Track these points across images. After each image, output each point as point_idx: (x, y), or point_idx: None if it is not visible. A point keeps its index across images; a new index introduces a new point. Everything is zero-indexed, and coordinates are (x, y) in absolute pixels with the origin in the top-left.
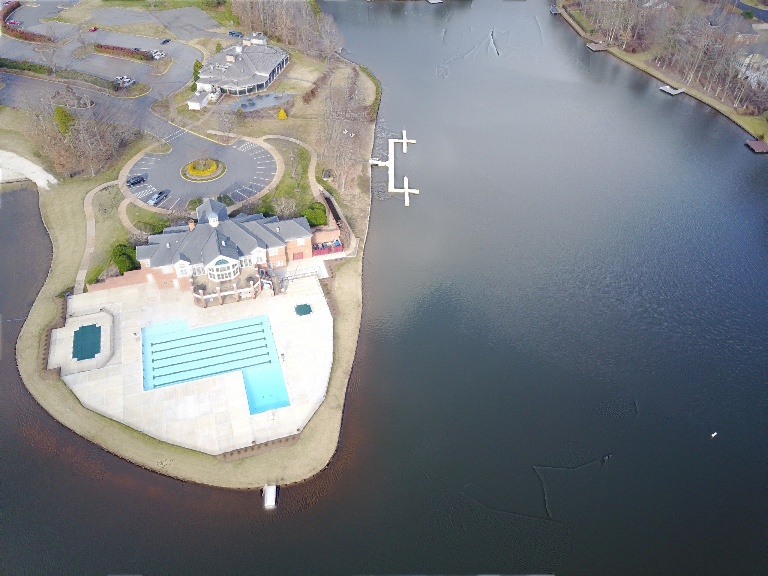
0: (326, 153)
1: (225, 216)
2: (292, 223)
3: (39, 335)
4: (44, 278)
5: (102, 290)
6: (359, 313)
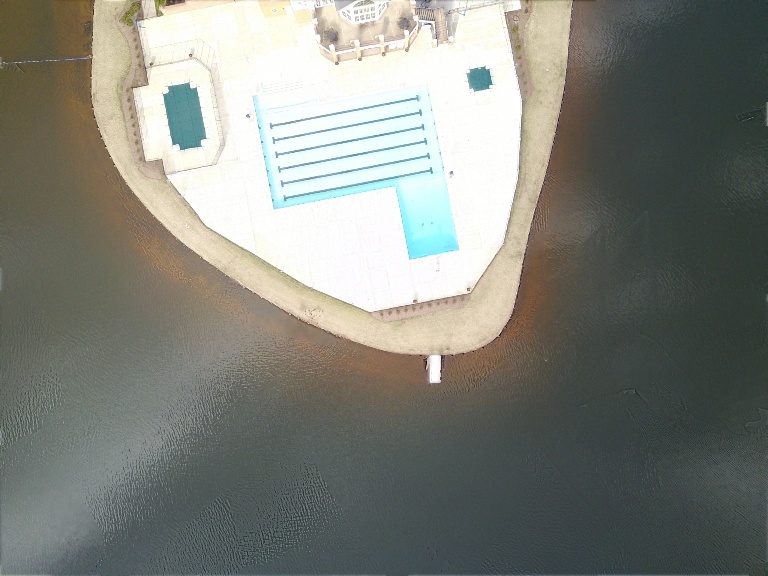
0: None
1: None
2: None
3: (118, 97)
4: None
5: (183, 12)
6: (560, 89)
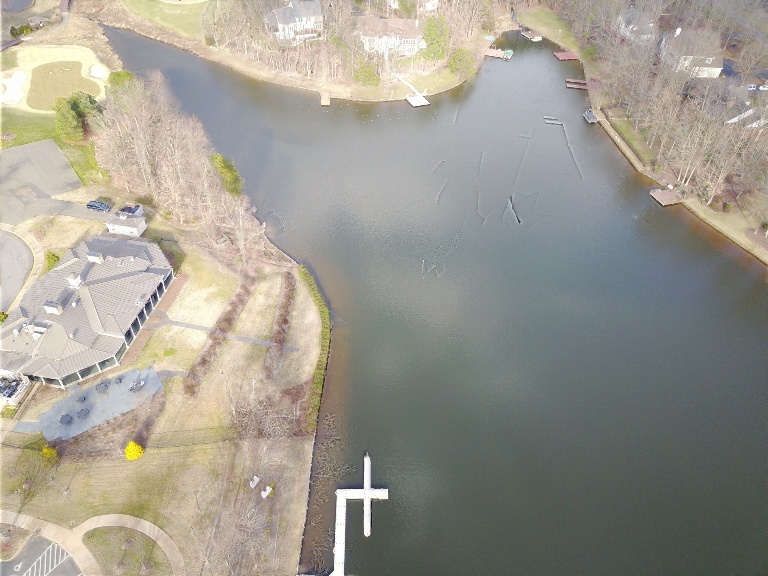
0: (207, 568)
1: None
2: None
3: None
4: None
5: None
6: None
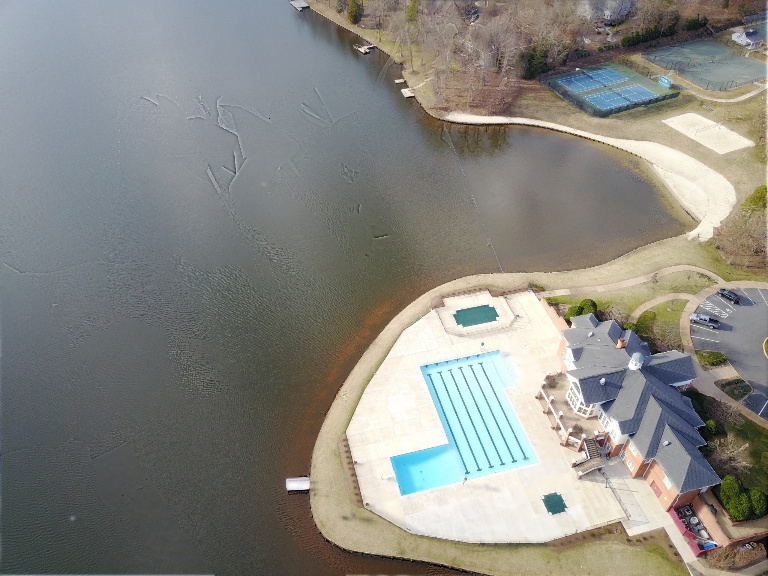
0: None
1: (669, 380)
2: (686, 459)
3: (481, 285)
4: (557, 271)
5: (545, 311)
6: None
